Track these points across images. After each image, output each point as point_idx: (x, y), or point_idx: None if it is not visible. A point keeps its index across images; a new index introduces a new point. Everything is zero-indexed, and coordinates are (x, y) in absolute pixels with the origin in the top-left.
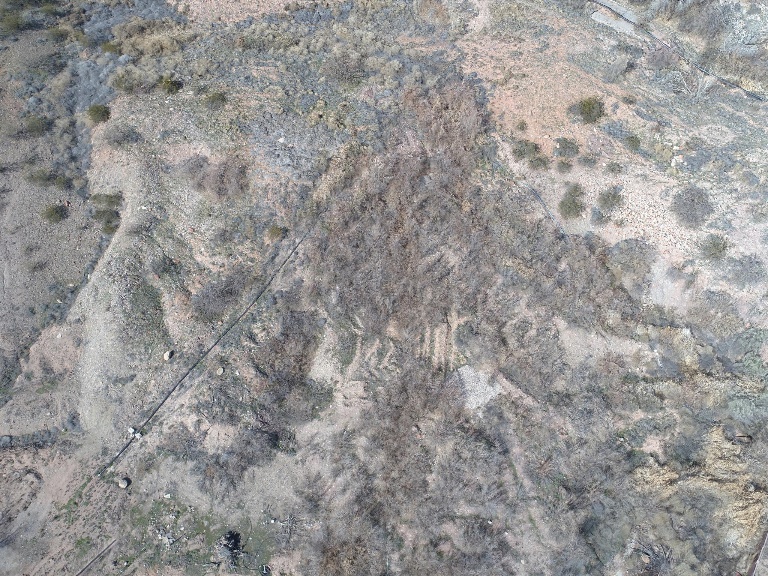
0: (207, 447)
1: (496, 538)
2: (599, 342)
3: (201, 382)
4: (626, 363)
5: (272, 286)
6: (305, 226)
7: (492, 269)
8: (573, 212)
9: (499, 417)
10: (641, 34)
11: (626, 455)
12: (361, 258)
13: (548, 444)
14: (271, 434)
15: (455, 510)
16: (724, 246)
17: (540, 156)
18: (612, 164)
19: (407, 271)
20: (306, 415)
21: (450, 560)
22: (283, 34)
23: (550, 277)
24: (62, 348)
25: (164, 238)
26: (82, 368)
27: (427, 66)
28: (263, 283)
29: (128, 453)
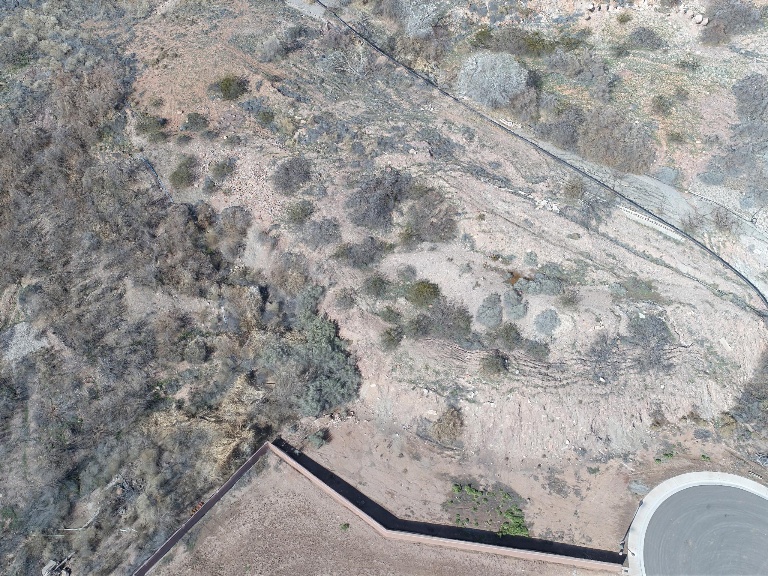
0: None
1: None
2: (165, 300)
3: None
4: (193, 319)
5: None
6: None
7: None
8: (185, 182)
9: (28, 367)
10: (329, 17)
11: (146, 401)
12: None
13: (70, 391)
14: None
15: None
16: (311, 211)
17: (164, 130)
18: (233, 137)
19: None
20: None
21: None
22: None
23: (132, 241)
24: None
25: None
26: None
27: (96, 48)
28: None
29: None
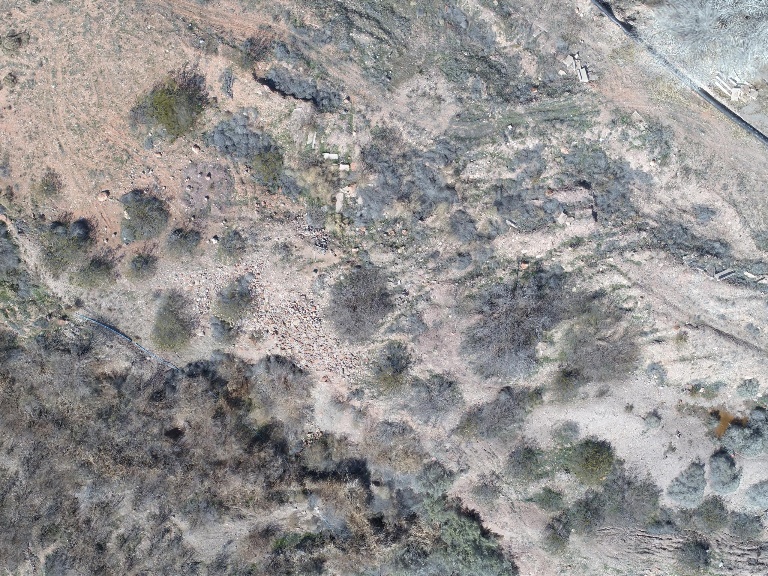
0: None
1: None
2: (238, 525)
3: None
4: (282, 526)
5: None
6: None
7: (73, 465)
8: (180, 334)
9: None
10: None
11: None
12: None
13: None
14: None
15: None
16: (407, 361)
17: (97, 252)
18: (229, 236)
19: None
20: None
21: None
22: None
23: (154, 467)
24: None
25: None
26: None
27: None
28: None
29: None
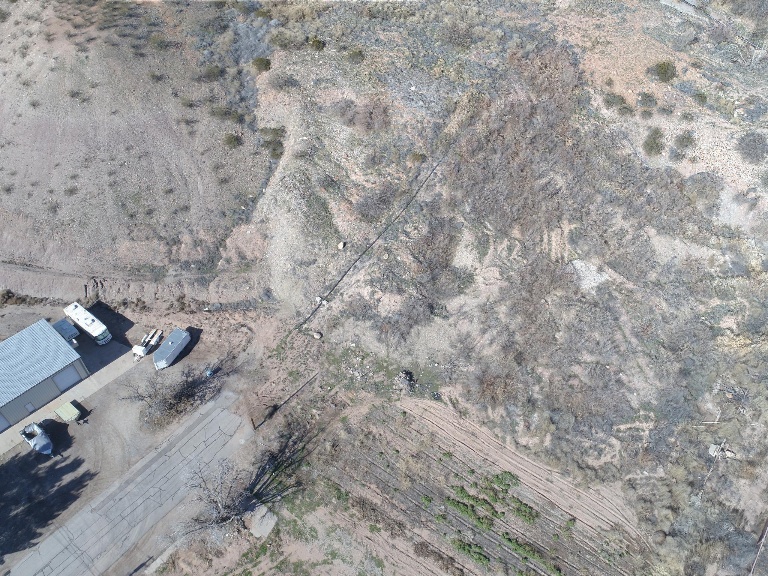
0: (380, 311)
1: (613, 377)
2: (682, 247)
3: (372, 264)
4: None
5: (418, 197)
6: (441, 153)
7: (592, 190)
8: (655, 150)
9: (609, 294)
10: (701, 15)
11: None
12: (488, 178)
13: (648, 315)
14: (428, 304)
15: (580, 358)
16: None
17: (626, 106)
18: (685, 114)
19: (526, 188)
20: (454, 292)
21: (580, 390)
22: (401, 7)
23: (641, 197)
24: (252, 241)
25: (324, 161)
26: (270, 256)
27: (525, 35)
28: (410, 195)
29: (317, 315)
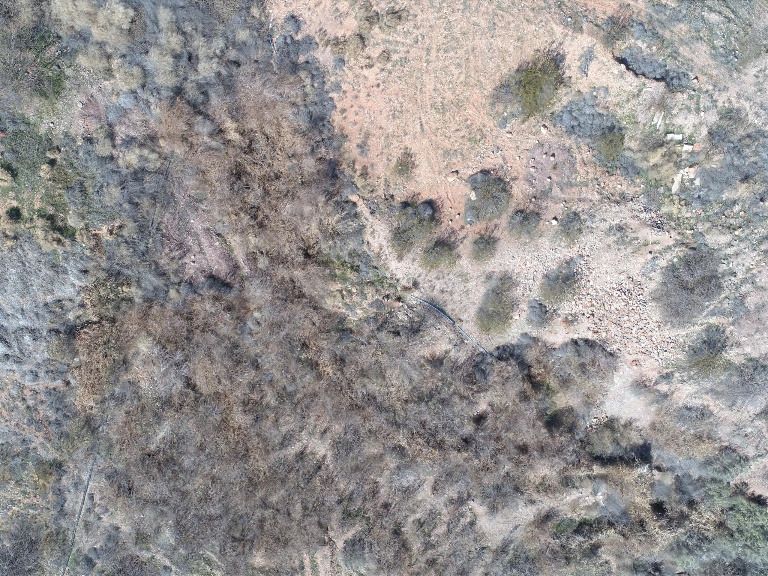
0: None
1: None
2: (528, 510)
3: None
4: (561, 512)
5: (79, 544)
6: None
7: (380, 449)
8: (499, 317)
9: None
10: None
11: None
12: None
13: None
14: None
15: None
16: (723, 345)
17: (441, 233)
18: (568, 217)
19: None
20: None
21: None
22: None
23: (463, 451)
24: None
25: None
26: None
27: (189, 1)
28: (64, 543)
29: None
